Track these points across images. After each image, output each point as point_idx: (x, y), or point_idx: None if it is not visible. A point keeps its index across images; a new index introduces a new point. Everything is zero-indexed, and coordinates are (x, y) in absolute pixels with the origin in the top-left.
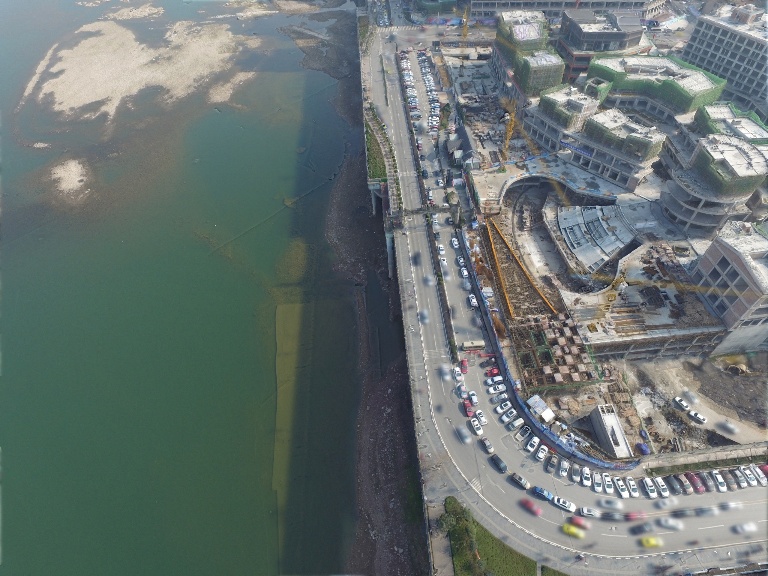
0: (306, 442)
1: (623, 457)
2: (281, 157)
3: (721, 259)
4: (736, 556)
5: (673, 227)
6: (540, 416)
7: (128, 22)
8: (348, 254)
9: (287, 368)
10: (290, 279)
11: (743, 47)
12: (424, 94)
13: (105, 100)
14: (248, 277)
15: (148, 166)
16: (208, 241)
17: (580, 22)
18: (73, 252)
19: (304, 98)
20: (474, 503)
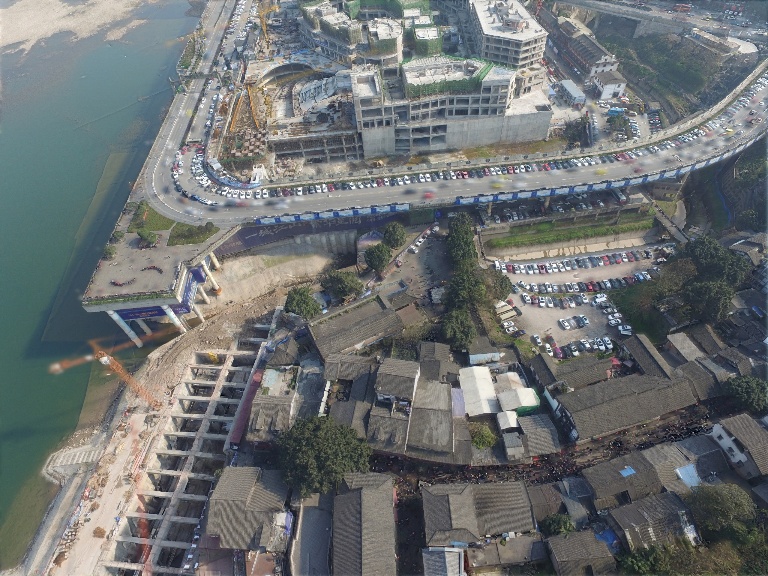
0: (103, 217)
1: None
2: (148, 74)
3: None
4: None
5: None
6: (211, 167)
7: None
8: None
9: (105, 184)
10: (125, 140)
11: None
12: (245, 19)
13: (25, 41)
14: (97, 141)
15: (46, 81)
16: (75, 122)
17: None
18: None
19: (179, 35)
20: (155, 203)
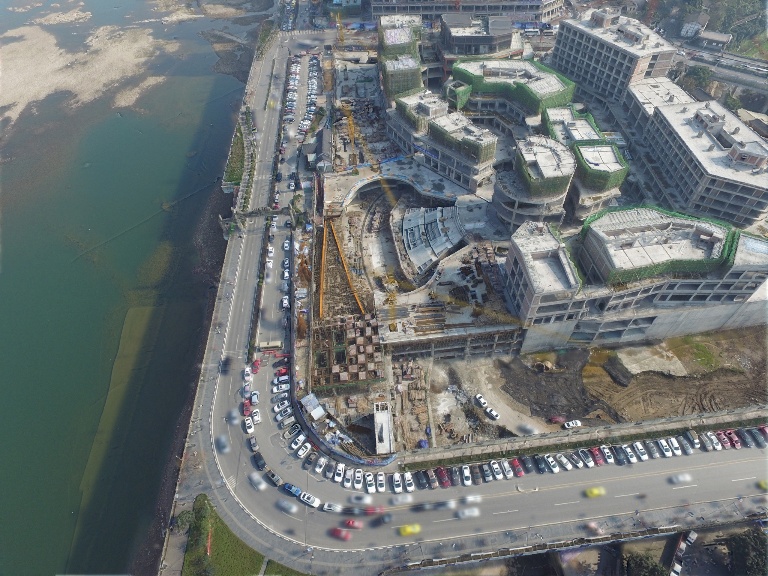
0: (123, 443)
1: (383, 453)
2: (172, 161)
3: (514, 259)
4: (459, 548)
5: (502, 227)
6: (309, 414)
7: (53, 27)
8: (210, 257)
9: (123, 370)
10: (148, 282)
11: (596, 50)
12: (304, 98)
13: (11, 105)
14: (108, 281)
15: (37, 171)
16: (77, 245)
17: (456, 26)
18: None
19: (207, 102)
20: (223, 500)
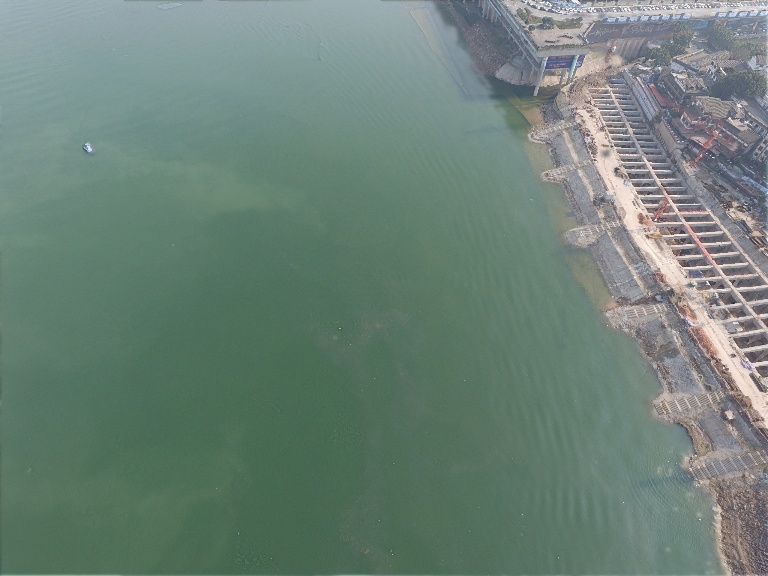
0: None
1: None
2: None
3: None
4: None
5: None
6: None
7: None
8: None
9: (424, 26)
10: (412, 4)
11: None
12: None
13: None
14: (389, 4)
15: None
16: None
17: None
18: None
19: None
20: None
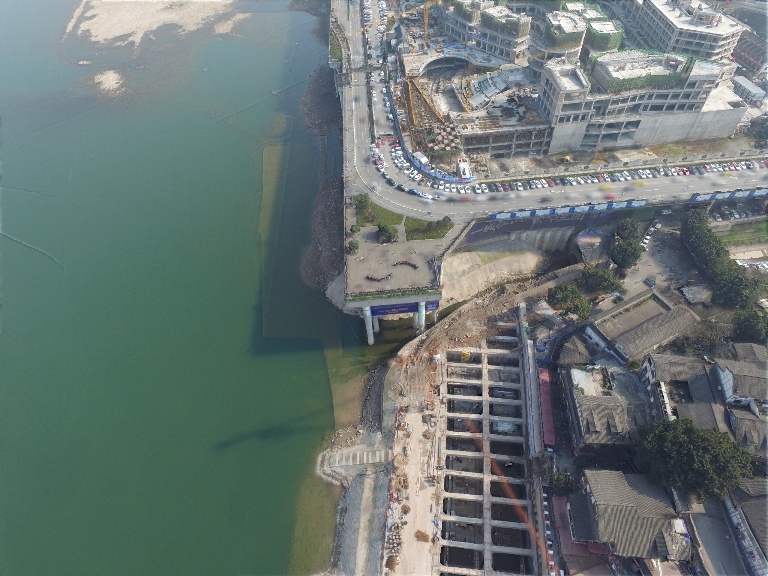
0: (281, 212)
1: None
2: (270, 67)
3: (546, 80)
4: None
5: (535, 79)
6: (419, 160)
7: None
8: (316, 119)
9: (270, 178)
10: (274, 134)
11: None
12: (377, 13)
13: (131, 33)
14: (244, 134)
15: (168, 73)
16: (215, 115)
17: None
18: (116, 123)
19: (289, 29)
20: (373, 196)
